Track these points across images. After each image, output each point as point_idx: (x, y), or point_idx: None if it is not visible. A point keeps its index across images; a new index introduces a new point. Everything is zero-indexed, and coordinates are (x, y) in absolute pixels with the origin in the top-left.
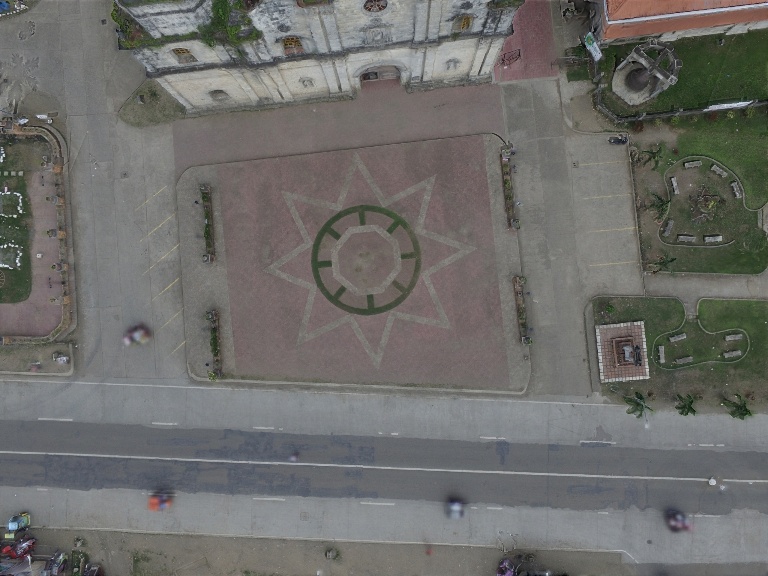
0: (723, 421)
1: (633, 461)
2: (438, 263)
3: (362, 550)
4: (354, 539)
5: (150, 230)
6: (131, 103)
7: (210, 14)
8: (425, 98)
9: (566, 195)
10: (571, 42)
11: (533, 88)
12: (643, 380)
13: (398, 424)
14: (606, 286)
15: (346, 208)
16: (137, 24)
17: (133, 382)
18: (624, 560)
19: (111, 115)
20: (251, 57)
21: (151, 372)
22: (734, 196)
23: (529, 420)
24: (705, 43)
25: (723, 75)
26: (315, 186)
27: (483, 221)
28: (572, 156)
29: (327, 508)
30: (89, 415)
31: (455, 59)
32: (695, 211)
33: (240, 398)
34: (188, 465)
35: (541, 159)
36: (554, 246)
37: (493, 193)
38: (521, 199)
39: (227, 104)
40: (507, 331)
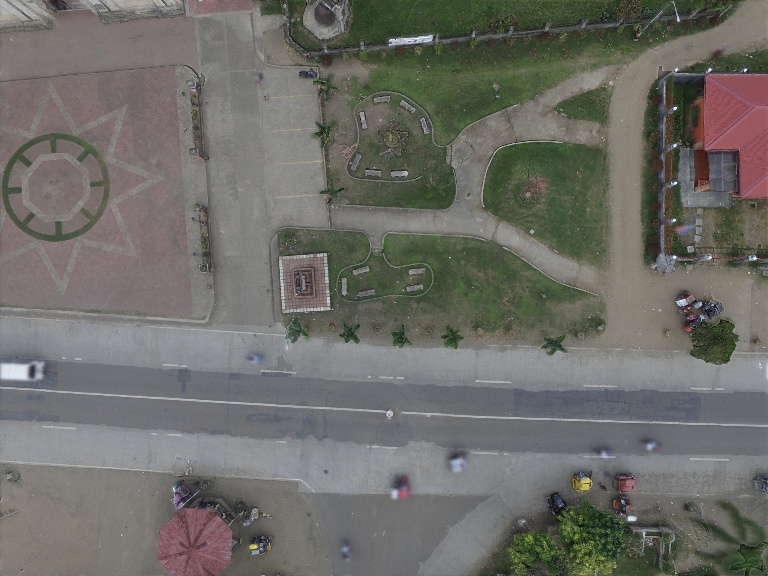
0: (404, 354)
1: (312, 391)
2: (126, 192)
3: (44, 473)
4: (35, 462)
5: None
6: None
7: None
8: (121, 29)
9: (256, 127)
10: None
11: (227, 21)
12: (325, 312)
13: (82, 349)
14: (292, 218)
15: (38, 136)
16: None
17: None
18: (301, 489)
19: None
20: None
21: None
22: (423, 132)
23: (211, 349)
24: None
25: (415, 12)
26: (8, 114)
27: (172, 151)
28: (263, 89)
29: (9, 431)
30: None
31: None
32: (382, 146)
33: None
34: None
35: (232, 91)
36: (242, 177)
37: (182, 124)
38: (211, 130)
39: None
40: (192, 260)
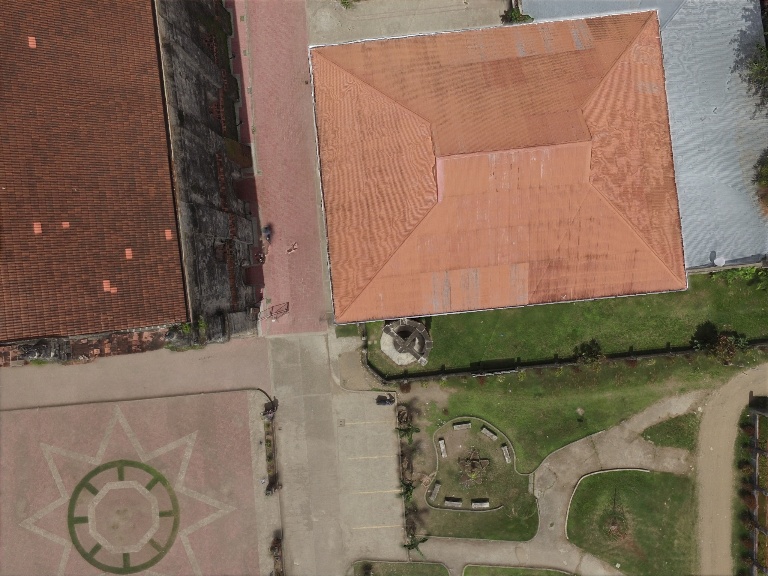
0: None
1: None
2: (196, 522)
3: None
4: None
5: None
6: None
7: None
8: (190, 350)
9: (331, 454)
10: None
11: (301, 343)
12: None
13: None
14: (369, 550)
15: (105, 463)
16: None
17: None
18: None
19: None
20: None
21: None
22: (504, 460)
23: None
24: None
25: (496, 334)
26: (74, 439)
27: (244, 480)
28: (339, 414)
29: None
30: None
31: None
32: (463, 475)
33: None
34: None
35: (306, 417)
36: (317, 507)
37: (255, 451)
38: (285, 457)
39: None
40: None
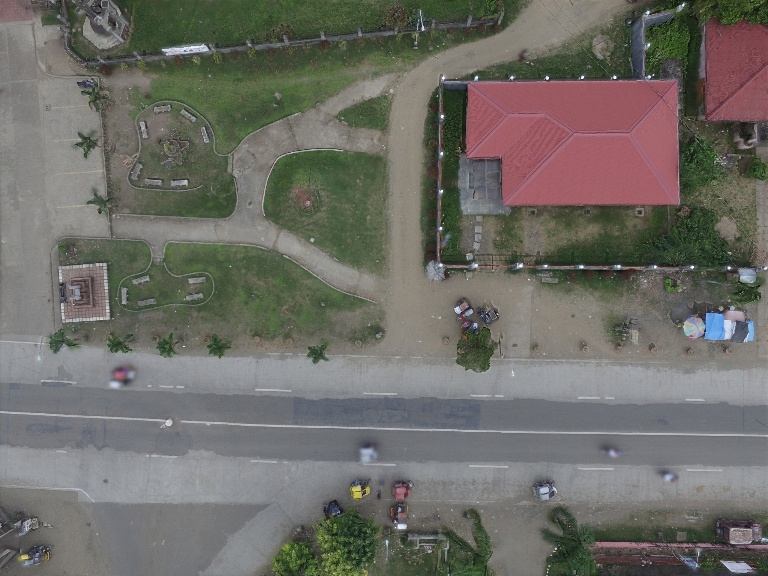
0: (185, 363)
1: (92, 401)
2: None
3: None
4: None
5: None
6: None
7: None
8: None
9: (37, 137)
10: None
11: (8, 32)
12: (106, 321)
13: None
14: (73, 228)
15: None
16: None
17: None
18: (81, 499)
19: None
20: None
21: None
22: None
23: None
24: None
25: (195, 21)
26: None
27: None
28: (45, 99)
29: None
30: None
31: None
32: (162, 155)
33: None
34: None
35: (13, 102)
36: (23, 188)
37: None
38: None
39: None
40: None
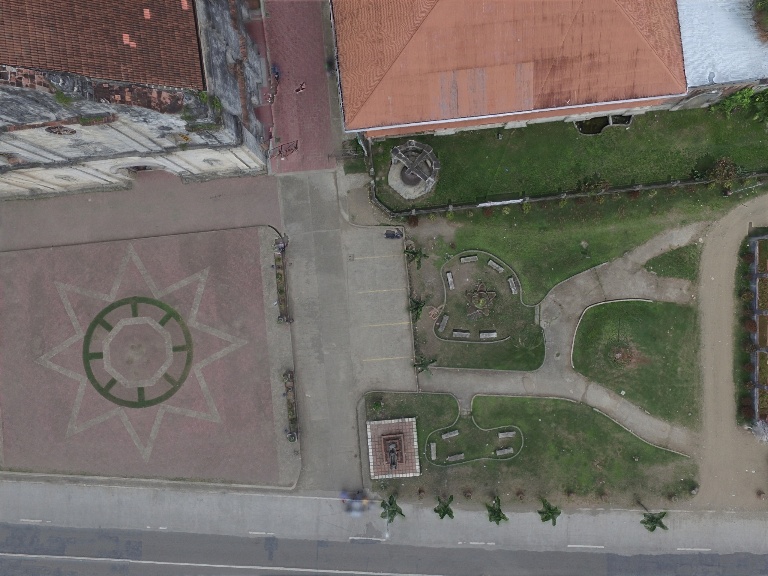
0: None
1: (402, 559)
2: (210, 356)
3: None
4: None
5: None
6: None
7: None
8: (201, 189)
9: (341, 289)
10: (349, 134)
11: (310, 180)
12: (414, 477)
13: (167, 518)
14: (379, 381)
15: (119, 299)
16: None
17: None
18: None
19: None
20: None
21: None
22: (511, 292)
23: (299, 516)
24: (484, 137)
25: (501, 169)
26: (88, 277)
27: (256, 314)
28: (348, 249)
29: None
30: None
31: (209, 159)
32: (470, 307)
33: (8, 490)
34: None
35: (316, 252)
36: (328, 340)
37: (266, 286)
38: (295, 292)
39: None
40: (278, 426)
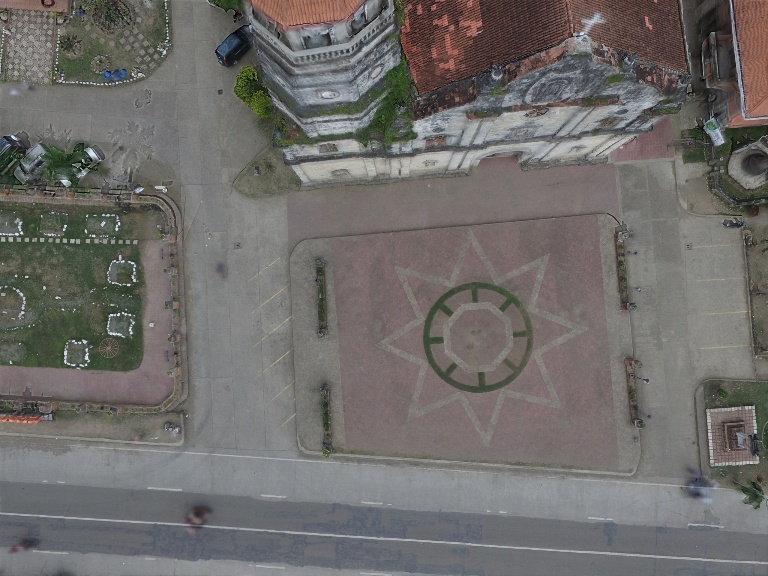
0: None
1: (741, 546)
2: (550, 342)
3: None
4: None
5: (262, 302)
6: (246, 174)
7: (371, 118)
8: (540, 176)
9: (679, 277)
10: (687, 124)
11: (648, 169)
12: (752, 464)
13: (506, 502)
14: (717, 369)
15: (459, 285)
16: (294, 124)
17: (243, 454)
18: None
19: (225, 185)
20: (393, 149)
21: (261, 444)
22: None
23: (637, 502)
24: None
25: None
26: (428, 262)
27: (596, 301)
28: (686, 238)
29: None
30: (198, 485)
31: (582, 146)
32: None
33: (349, 472)
34: (296, 538)
35: (655, 240)
36: (666, 328)
37: (606, 273)
38: (634, 280)
39: (343, 178)
40: (618, 412)
